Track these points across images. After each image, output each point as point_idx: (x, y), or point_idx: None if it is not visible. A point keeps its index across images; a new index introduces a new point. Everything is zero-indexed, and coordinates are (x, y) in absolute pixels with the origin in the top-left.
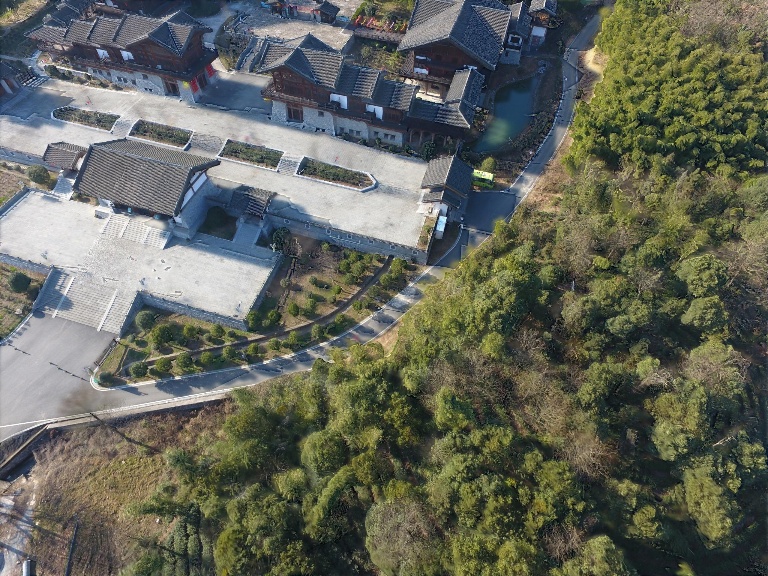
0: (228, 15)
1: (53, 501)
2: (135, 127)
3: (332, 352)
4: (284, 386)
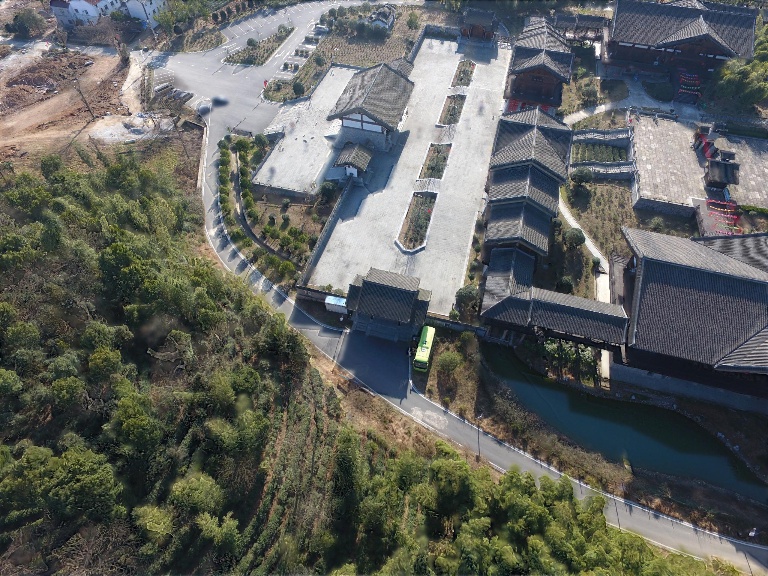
0: (665, 108)
1: (162, 141)
2: (458, 96)
3: (216, 237)
4: (182, 204)
